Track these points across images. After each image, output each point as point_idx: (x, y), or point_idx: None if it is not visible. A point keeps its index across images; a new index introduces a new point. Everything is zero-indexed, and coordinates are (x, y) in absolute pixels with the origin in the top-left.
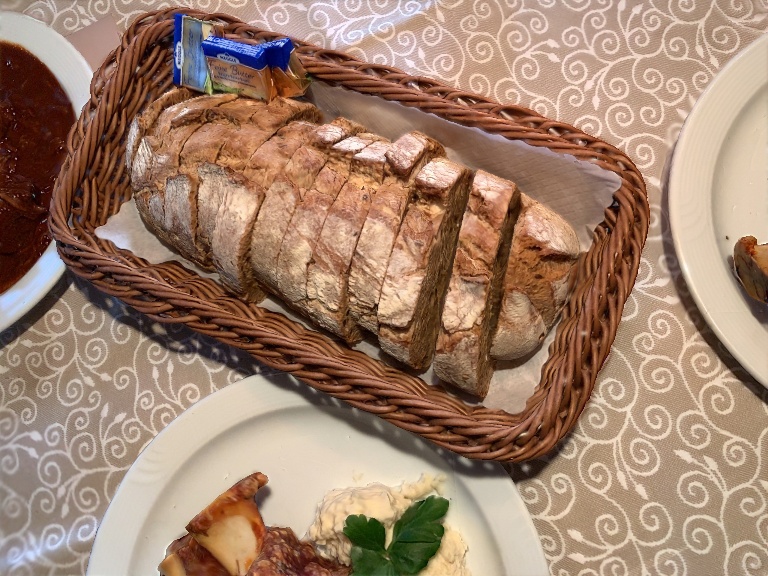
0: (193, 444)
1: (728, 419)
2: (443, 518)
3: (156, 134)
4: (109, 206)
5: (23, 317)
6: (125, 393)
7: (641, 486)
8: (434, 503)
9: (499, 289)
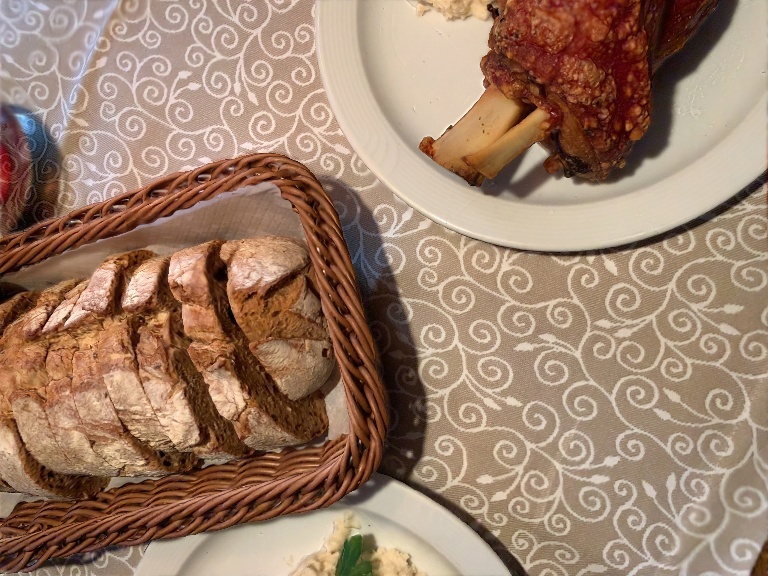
0: None
1: (534, 292)
2: (375, 545)
3: None
4: None
5: None
6: None
7: (510, 398)
8: (350, 546)
9: None
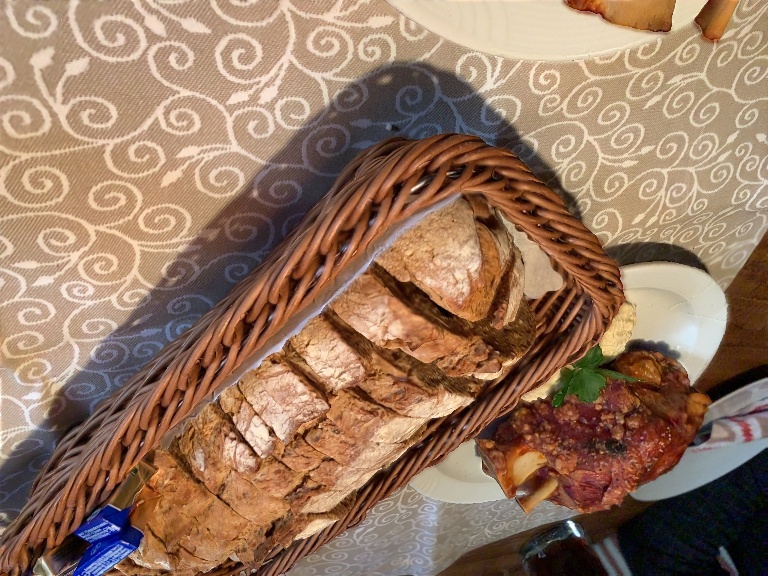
0: None
1: (664, 48)
2: None
3: None
4: None
5: None
6: None
7: (644, 149)
8: None
9: None
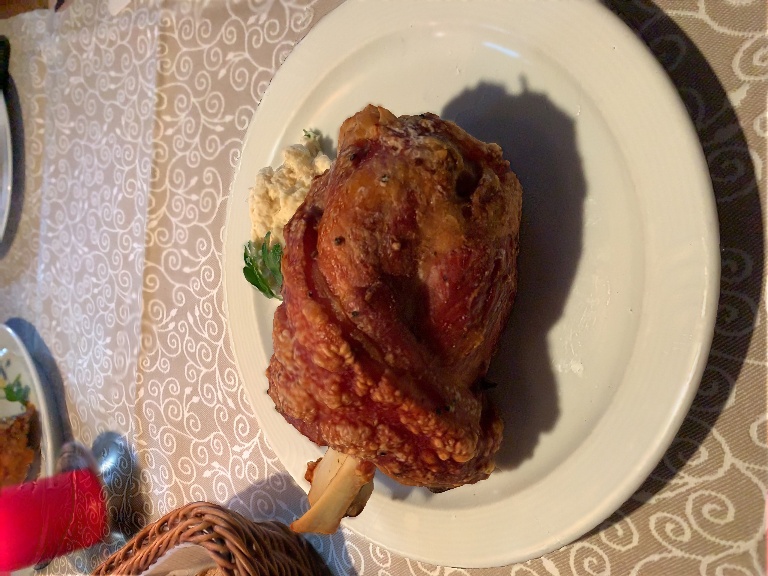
0: None
1: None
2: None
3: None
4: None
5: None
6: None
7: None
8: None
9: None
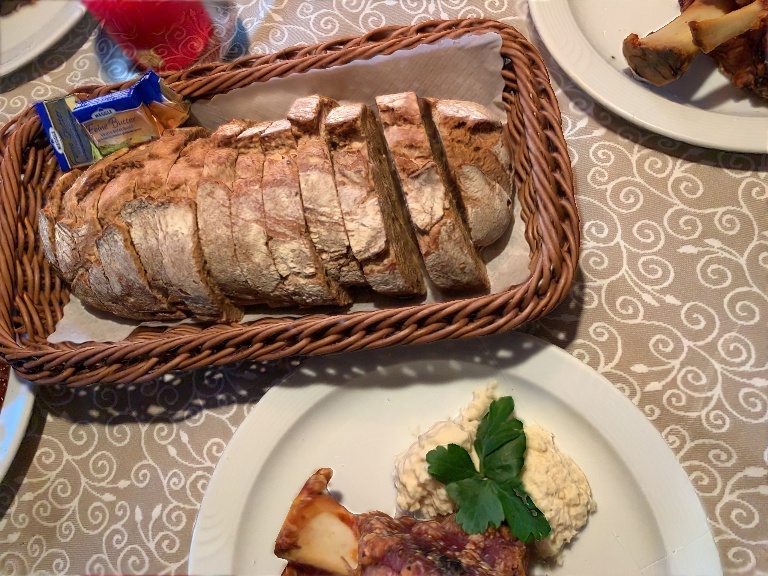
0: (242, 489)
1: (704, 198)
2: None
3: (66, 216)
4: (51, 314)
5: (11, 467)
6: (151, 486)
7: (669, 296)
8: (499, 405)
9: (449, 177)
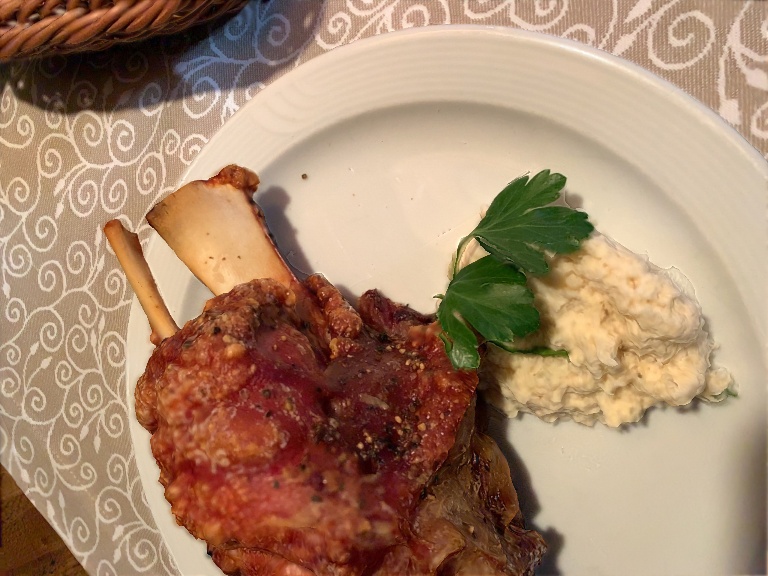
0: None
1: None
2: None
3: None
4: None
5: None
6: None
7: (62, 207)
8: None
9: None
